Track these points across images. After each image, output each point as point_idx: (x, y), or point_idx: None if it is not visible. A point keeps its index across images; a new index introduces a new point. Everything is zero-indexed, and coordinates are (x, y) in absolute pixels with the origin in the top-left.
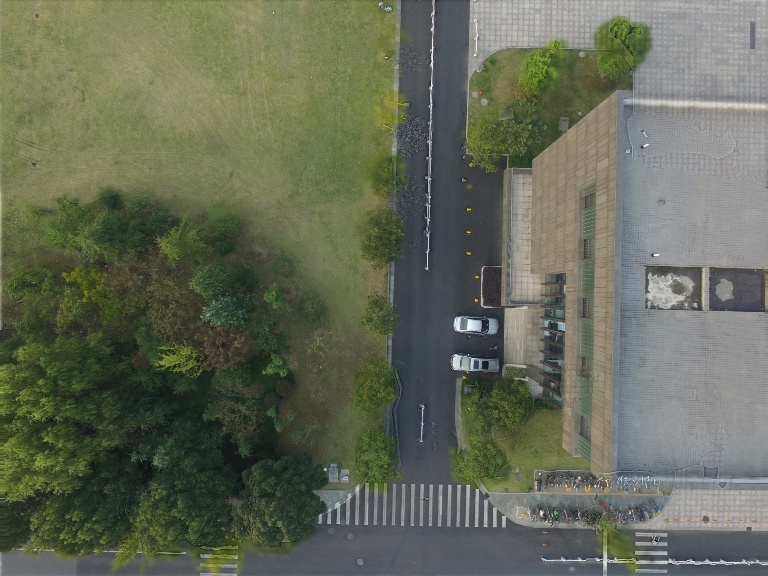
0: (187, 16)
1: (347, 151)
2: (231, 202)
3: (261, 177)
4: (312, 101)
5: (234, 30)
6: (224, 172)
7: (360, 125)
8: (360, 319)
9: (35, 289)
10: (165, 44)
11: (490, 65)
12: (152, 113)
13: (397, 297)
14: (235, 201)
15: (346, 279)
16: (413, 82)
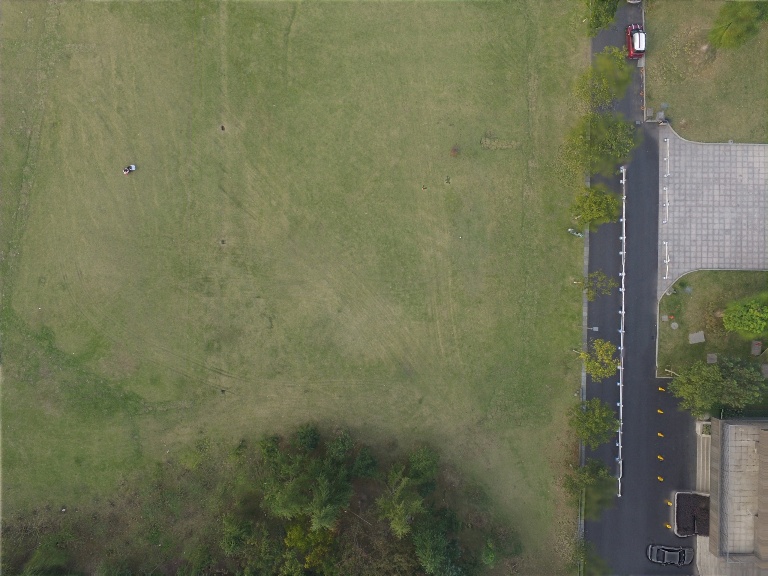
0: (374, 242)
1: (535, 375)
2: (421, 429)
3: (450, 404)
4: (500, 326)
5: (421, 256)
6: (414, 399)
7: (548, 349)
8: (552, 546)
9: (254, 550)
10: (352, 271)
11: (680, 288)
12: (341, 341)
13: (588, 522)
14: (425, 428)
15: (537, 506)
16: (602, 306)
